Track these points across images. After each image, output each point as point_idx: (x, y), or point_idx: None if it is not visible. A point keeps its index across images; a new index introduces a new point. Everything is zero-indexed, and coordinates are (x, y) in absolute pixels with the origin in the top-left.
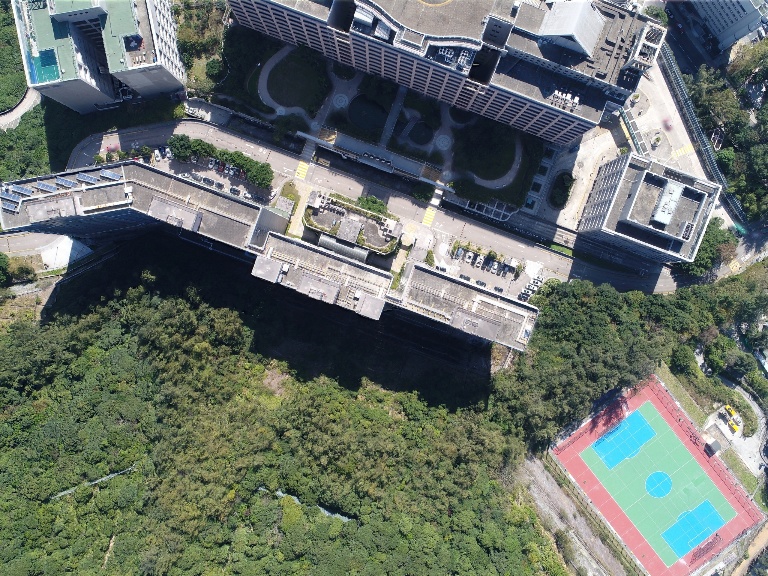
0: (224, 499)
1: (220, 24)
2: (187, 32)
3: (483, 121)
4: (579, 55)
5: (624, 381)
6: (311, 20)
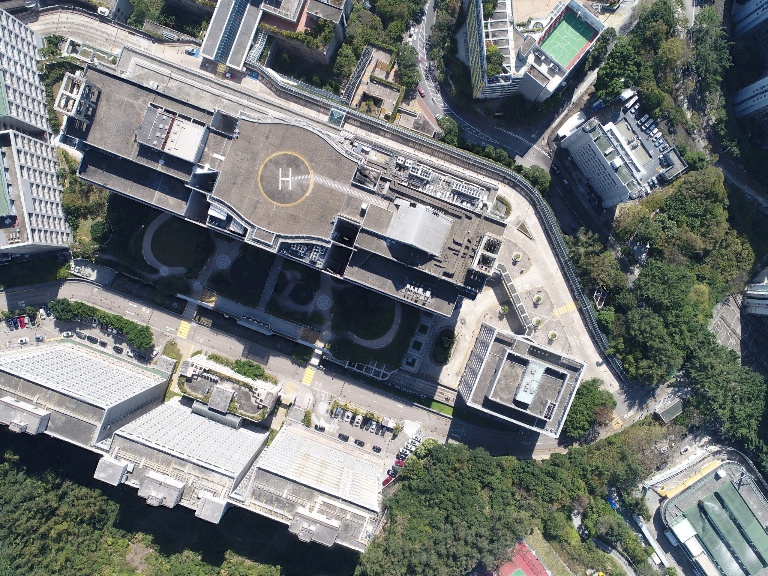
0: None
1: None
2: (71, 197)
3: (360, 286)
4: (427, 255)
5: (483, 562)
6: None
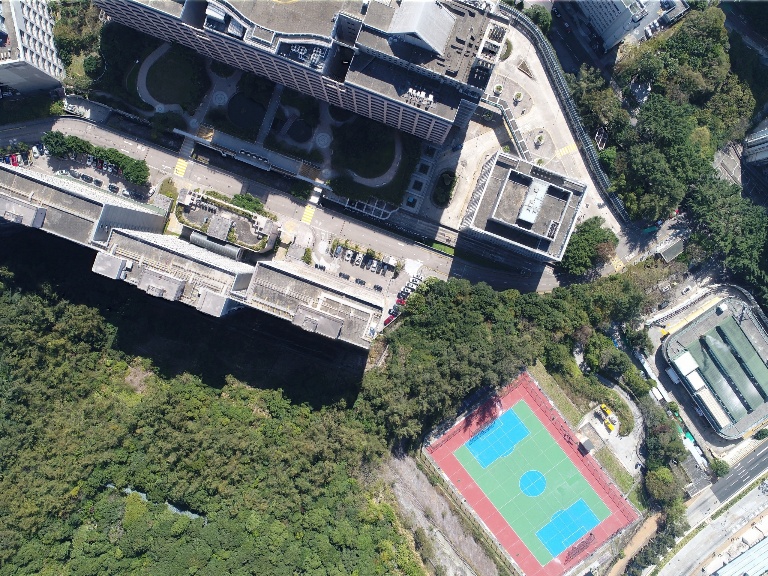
0: (65, 496)
1: (99, 21)
2: (63, 29)
3: (360, 119)
4: (429, 53)
5: (487, 379)
6: (166, 17)
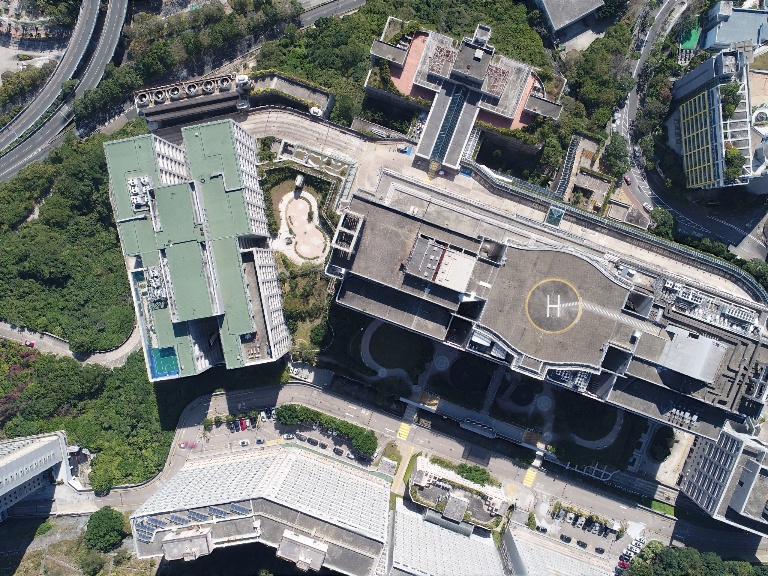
0: None
1: None
2: (293, 303)
3: None
4: (700, 382)
5: None
6: (427, 336)
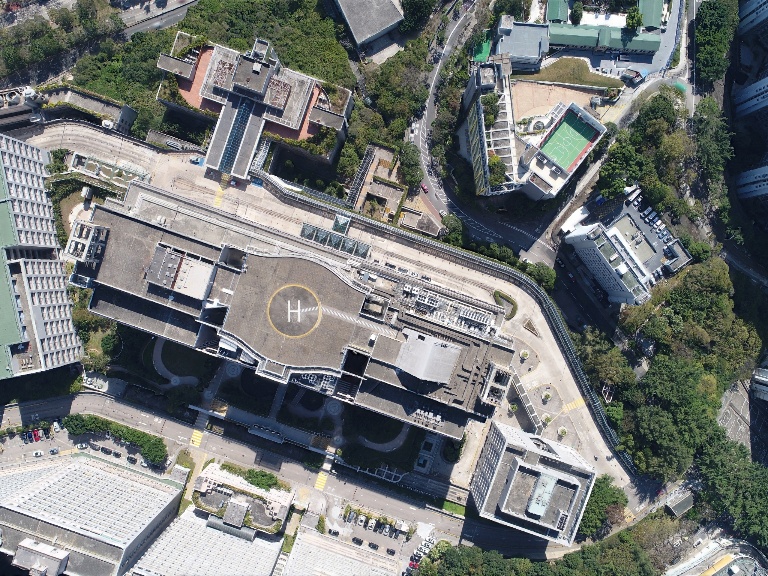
0: None
1: None
2: (81, 313)
3: None
4: None
5: None
6: (180, 343)
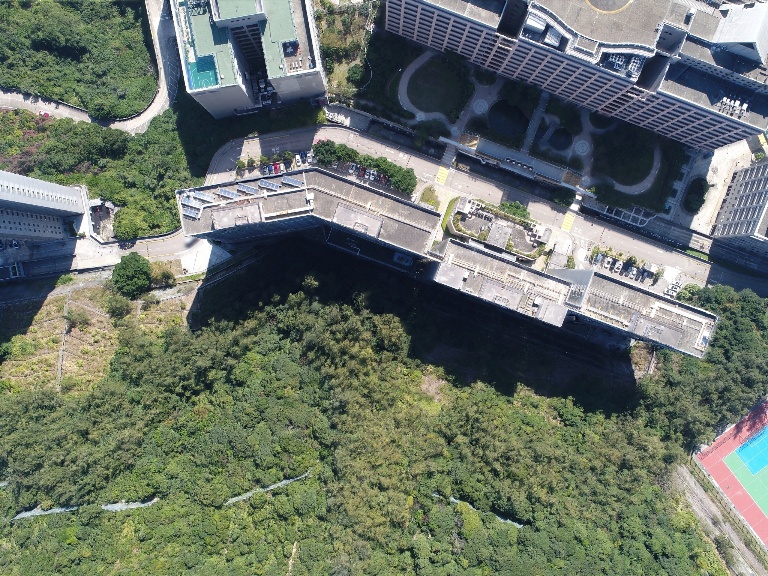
0: (406, 505)
1: (361, 29)
2: (331, 37)
3: (625, 127)
4: (752, 62)
5: None
6: (480, 27)
